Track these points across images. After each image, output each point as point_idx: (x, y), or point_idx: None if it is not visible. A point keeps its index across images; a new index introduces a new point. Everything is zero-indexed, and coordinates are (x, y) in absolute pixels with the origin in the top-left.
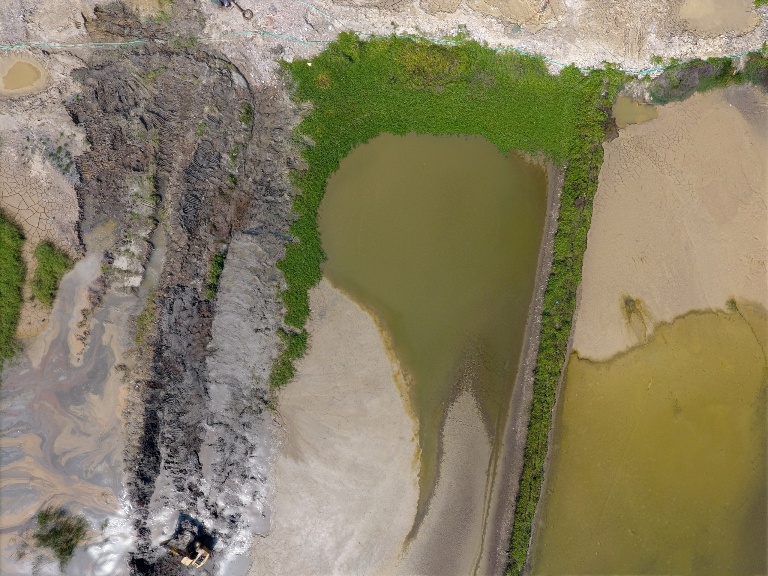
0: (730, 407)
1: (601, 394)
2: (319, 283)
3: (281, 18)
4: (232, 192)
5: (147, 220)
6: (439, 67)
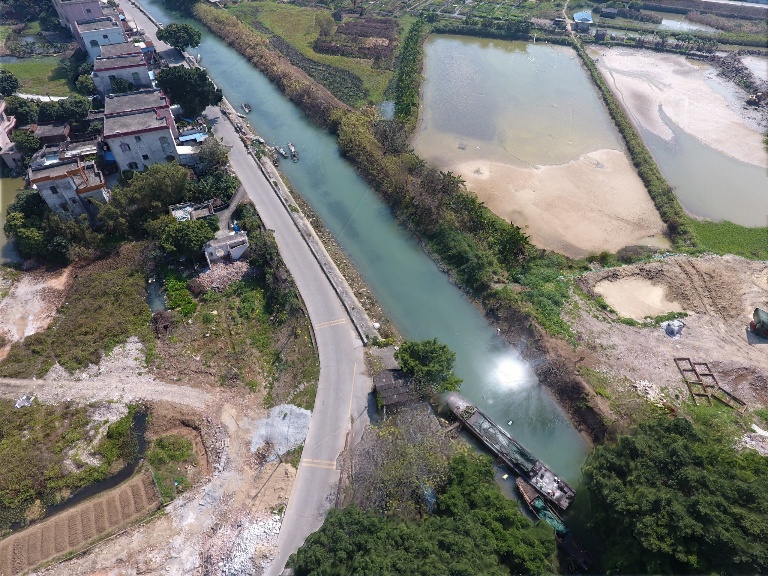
0: None
1: None
2: None
3: None
4: None
5: None
6: None
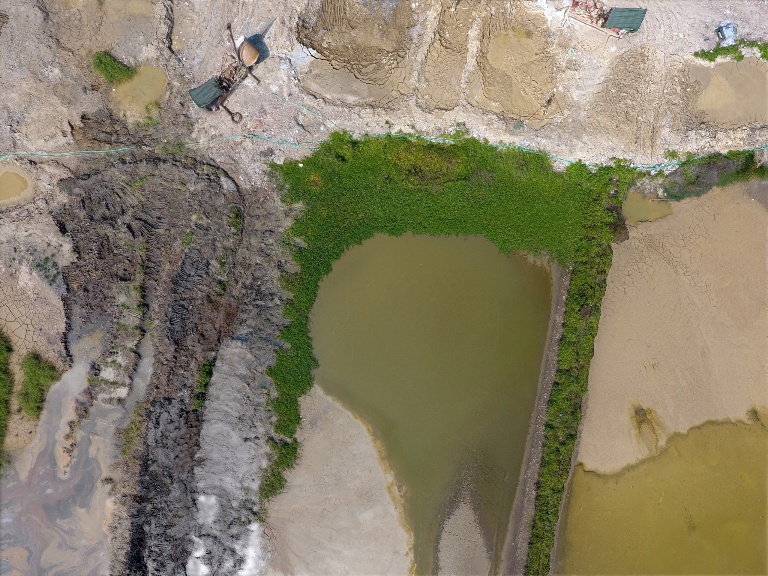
0: (749, 524)
1: (608, 509)
2: (310, 390)
3: (271, 120)
4: (221, 298)
5: (134, 331)
6: (436, 166)
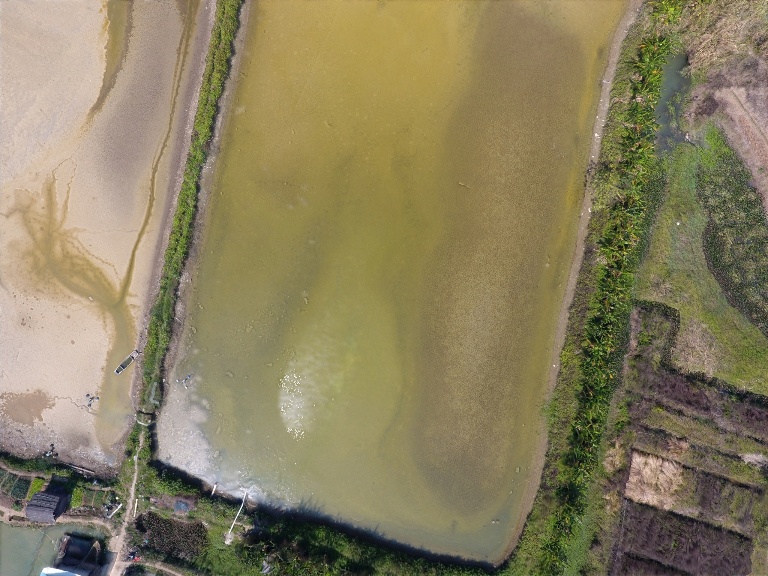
0: (437, 6)
1: None
2: None
3: None
4: None
5: None
6: None
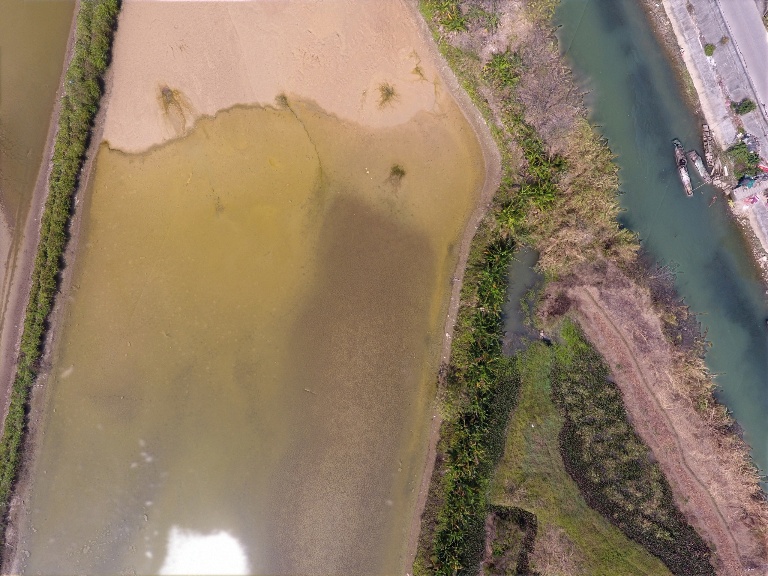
0: (279, 208)
1: (134, 188)
2: None
3: None
4: None
5: None
6: None
